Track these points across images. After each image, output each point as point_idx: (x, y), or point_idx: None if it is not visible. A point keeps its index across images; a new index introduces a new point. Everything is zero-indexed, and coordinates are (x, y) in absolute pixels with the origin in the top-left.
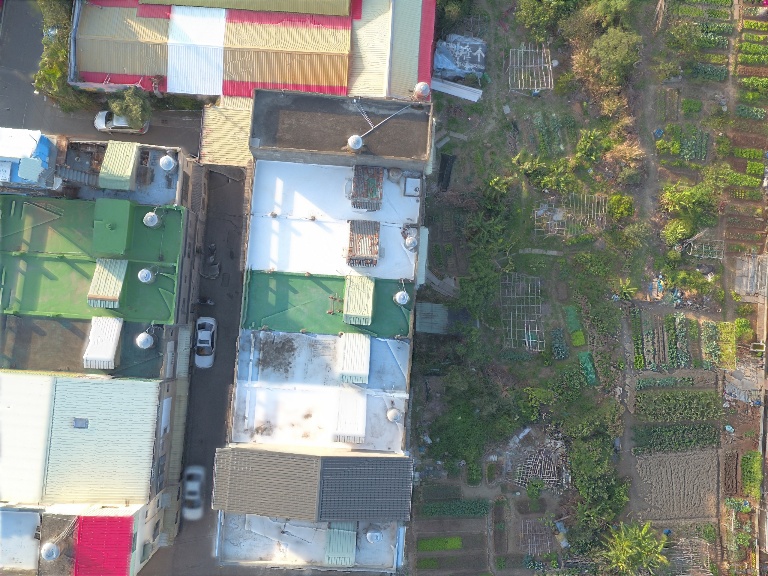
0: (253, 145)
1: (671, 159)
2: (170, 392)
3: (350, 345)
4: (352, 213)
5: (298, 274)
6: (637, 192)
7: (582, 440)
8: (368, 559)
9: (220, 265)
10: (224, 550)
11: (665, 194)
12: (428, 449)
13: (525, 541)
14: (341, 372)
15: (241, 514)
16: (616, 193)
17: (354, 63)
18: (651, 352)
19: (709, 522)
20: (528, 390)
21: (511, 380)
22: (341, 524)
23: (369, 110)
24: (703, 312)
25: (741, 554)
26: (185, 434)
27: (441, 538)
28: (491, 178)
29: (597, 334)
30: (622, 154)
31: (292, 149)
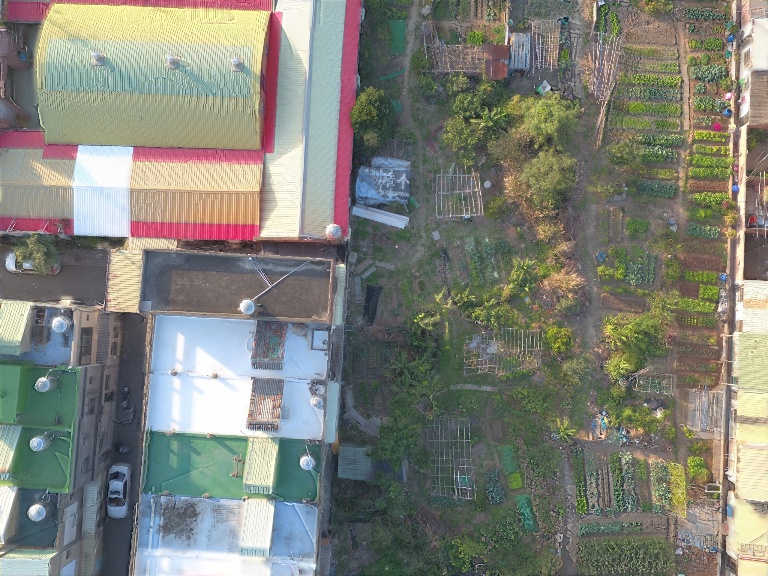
0: (144, 308)
1: (615, 284)
2: (72, 556)
3: (252, 514)
4: (256, 369)
5: (200, 435)
6: (578, 321)
7: None
8: None
9: (134, 409)
10: None
11: (606, 326)
12: None
13: None
14: (240, 545)
15: None
16: (555, 323)
17: (267, 199)
18: (595, 495)
19: None
20: (457, 542)
21: (441, 528)
22: None
23: (267, 267)
24: (652, 450)
25: None
26: None
27: None
28: (416, 314)
29: None
30: (559, 284)
31: (184, 313)
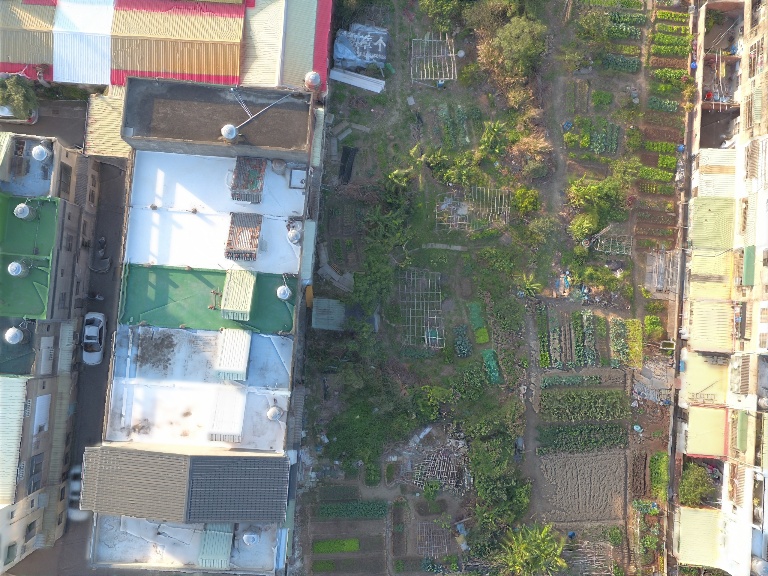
0: (126, 134)
1: (580, 152)
2: (48, 389)
3: (229, 341)
4: (235, 205)
5: (178, 268)
6: (545, 186)
7: (481, 440)
8: (248, 561)
9: (111, 259)
10: (98, 552)
11: (571, 188)
12: (325, 449)
13: (422, 543)
14: (217, 369)
15: (116, 515)
16: (523, 187)
17: (247, 52)
18: (557, 350)
19: (616, 524)
20: (426, 388)
21: (411, 378)
22: (217, 525)
23: (247, 99)
24: (612, 309)
25: (648, 557)
26: (72, 432)
27: (337, 540)
28: (391, 171)
29: (502, 331)
30: (527, 147)
31: (165, 139)
